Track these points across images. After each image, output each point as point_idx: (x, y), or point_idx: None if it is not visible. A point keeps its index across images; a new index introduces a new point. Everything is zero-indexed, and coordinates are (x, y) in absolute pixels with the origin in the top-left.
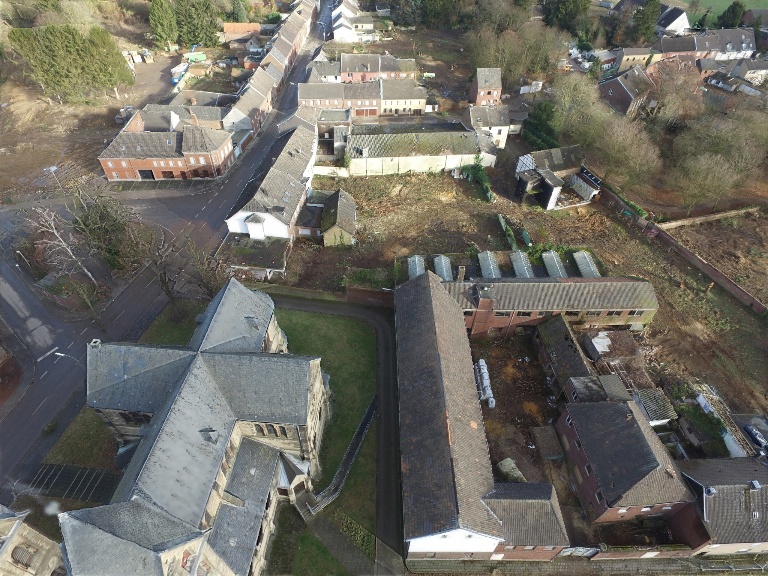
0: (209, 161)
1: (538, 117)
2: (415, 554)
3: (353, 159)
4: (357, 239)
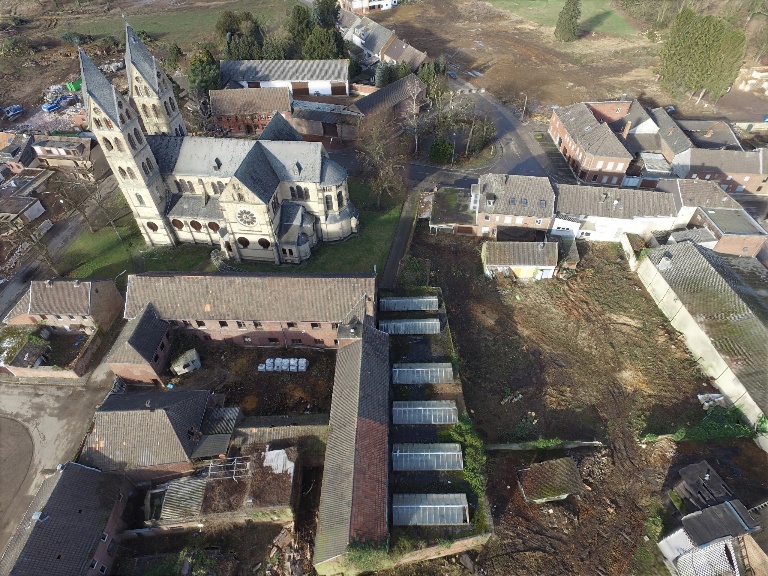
0: (583, 160)
1: None
2: None
3: (648, 258)
4: (495, 277)
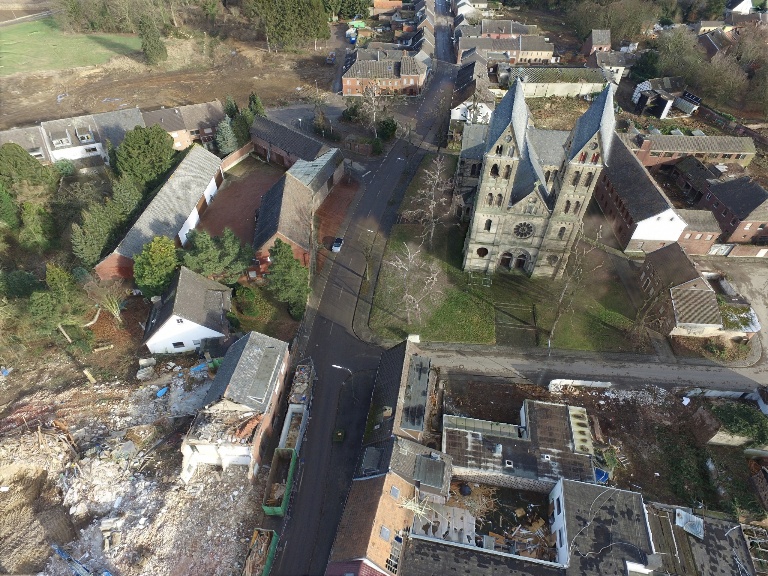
0: (416, 82)
1: (644, 62)
2: (632, 244)
3: None
4: None
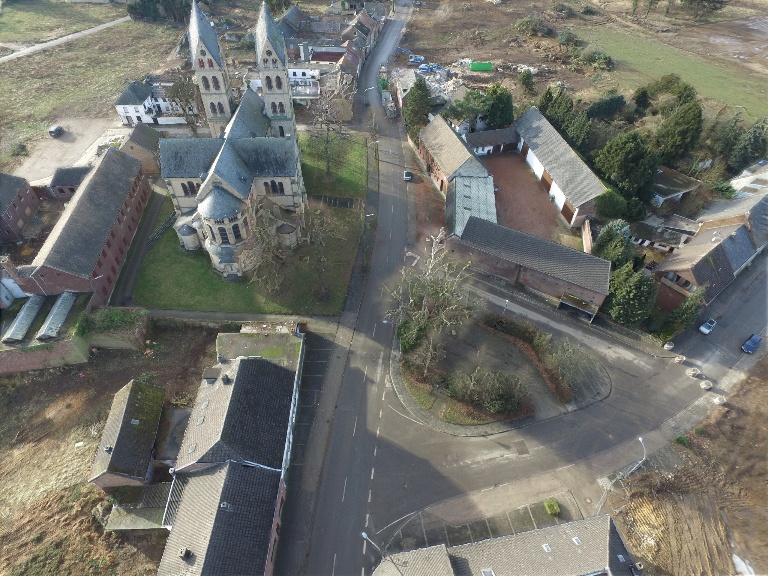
0: None
1: None
2: None
3: None
4: None
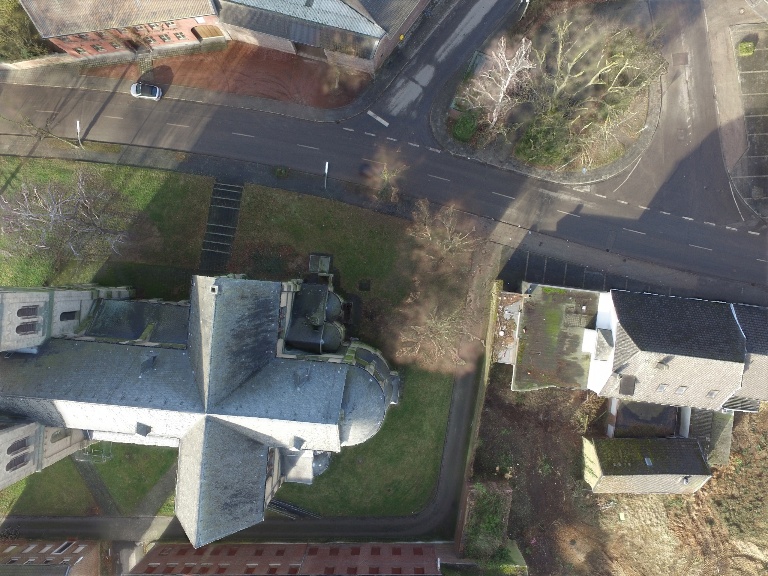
0: None
1: None
2: None
3: None
4: None
